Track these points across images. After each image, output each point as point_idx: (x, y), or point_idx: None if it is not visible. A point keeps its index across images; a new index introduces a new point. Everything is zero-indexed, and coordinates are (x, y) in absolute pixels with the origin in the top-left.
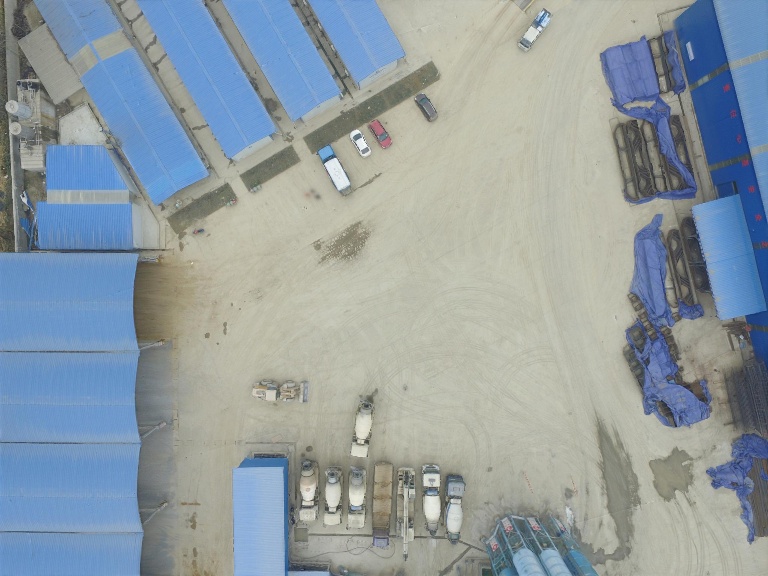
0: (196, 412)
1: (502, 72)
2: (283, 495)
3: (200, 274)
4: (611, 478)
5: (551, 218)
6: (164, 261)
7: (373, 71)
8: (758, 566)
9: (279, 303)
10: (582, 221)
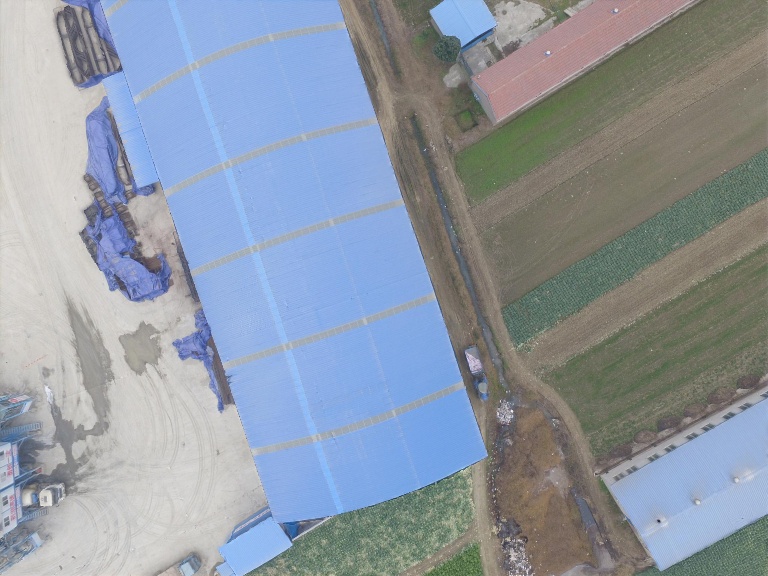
0: None
1: None
2: None
3: None
4: (84, 355)
5: (8, 107)
6: None
7: None
8: (231, 434)
9: None
10: (36, 108)
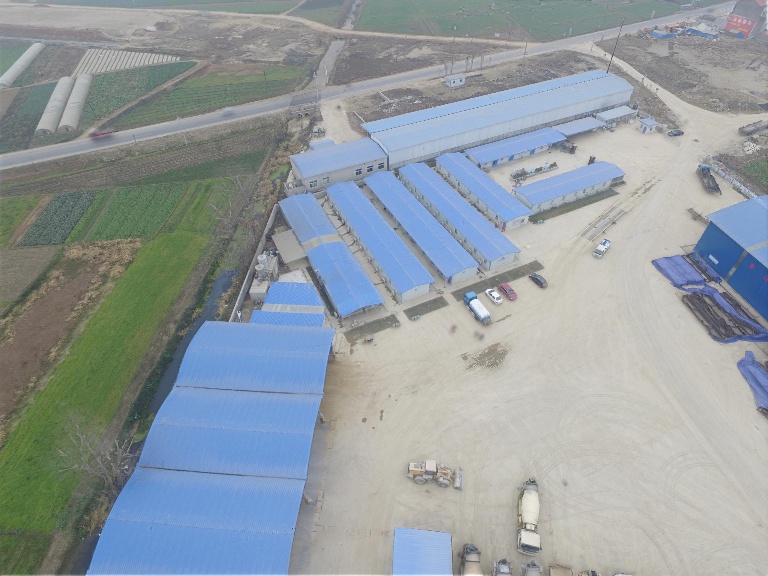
0: (343, 494)
1: (586, 267)
2: (452, 571)
3: (364, 371)
4: None
5: (658, 349)
6: (336, 359)
7: (501, 256)
8: None
9: (432, 397)
10: (685, 352)
